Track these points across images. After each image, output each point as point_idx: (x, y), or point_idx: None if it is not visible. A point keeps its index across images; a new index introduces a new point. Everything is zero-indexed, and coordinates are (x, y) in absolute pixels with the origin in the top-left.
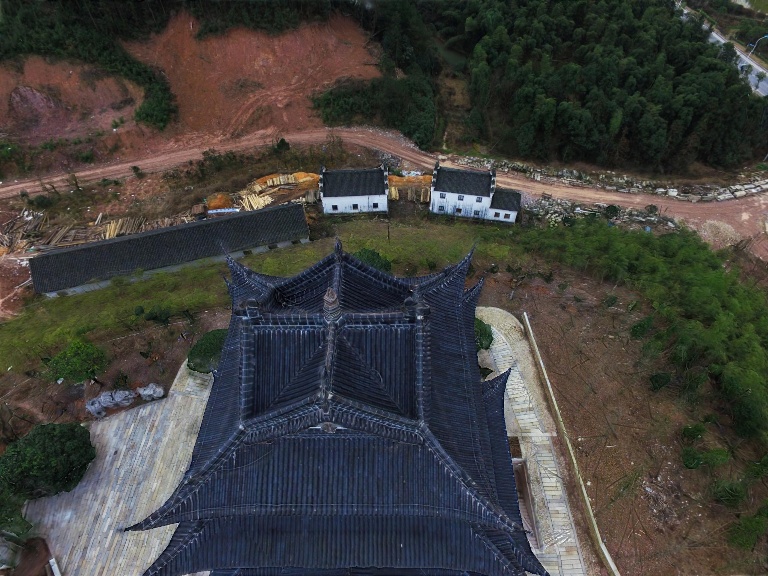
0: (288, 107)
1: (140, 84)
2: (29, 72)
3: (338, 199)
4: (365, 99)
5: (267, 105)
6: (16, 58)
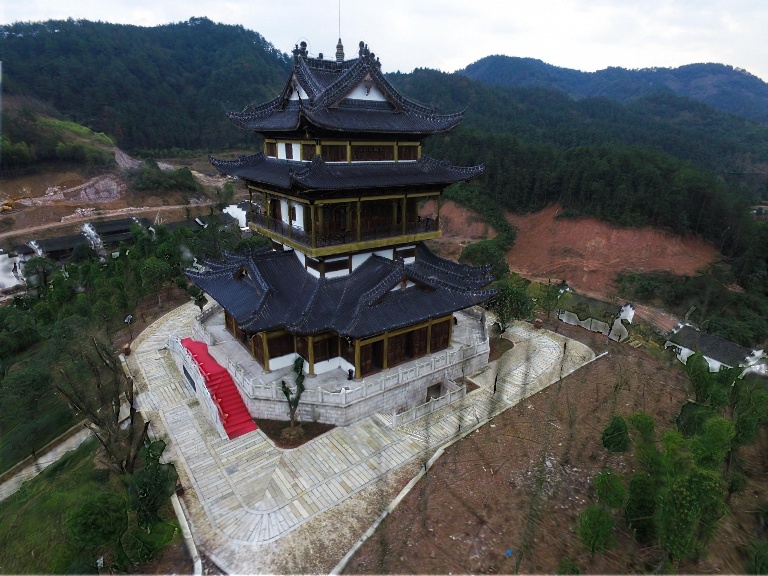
0: (592, 273)
1: (497, 231)
2: (444, 208)
3: (566, 314)
4: (674, 289)
5: (575, 266)
6: (443, 200)
